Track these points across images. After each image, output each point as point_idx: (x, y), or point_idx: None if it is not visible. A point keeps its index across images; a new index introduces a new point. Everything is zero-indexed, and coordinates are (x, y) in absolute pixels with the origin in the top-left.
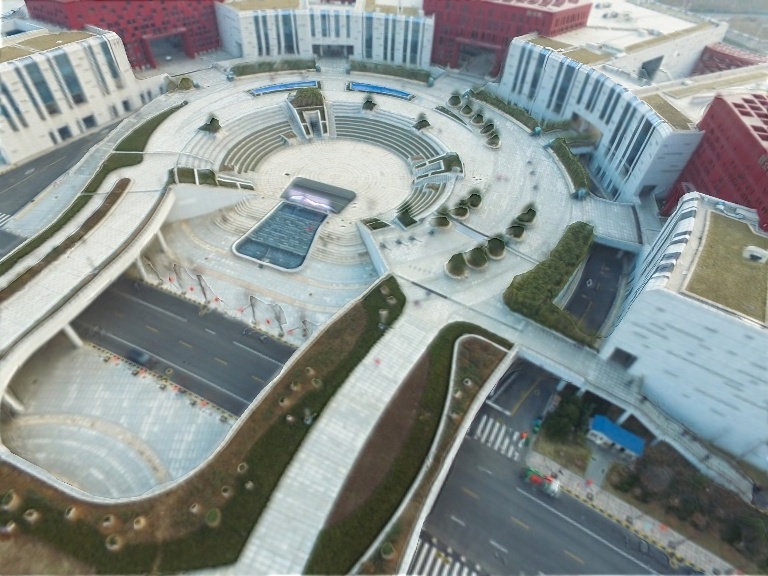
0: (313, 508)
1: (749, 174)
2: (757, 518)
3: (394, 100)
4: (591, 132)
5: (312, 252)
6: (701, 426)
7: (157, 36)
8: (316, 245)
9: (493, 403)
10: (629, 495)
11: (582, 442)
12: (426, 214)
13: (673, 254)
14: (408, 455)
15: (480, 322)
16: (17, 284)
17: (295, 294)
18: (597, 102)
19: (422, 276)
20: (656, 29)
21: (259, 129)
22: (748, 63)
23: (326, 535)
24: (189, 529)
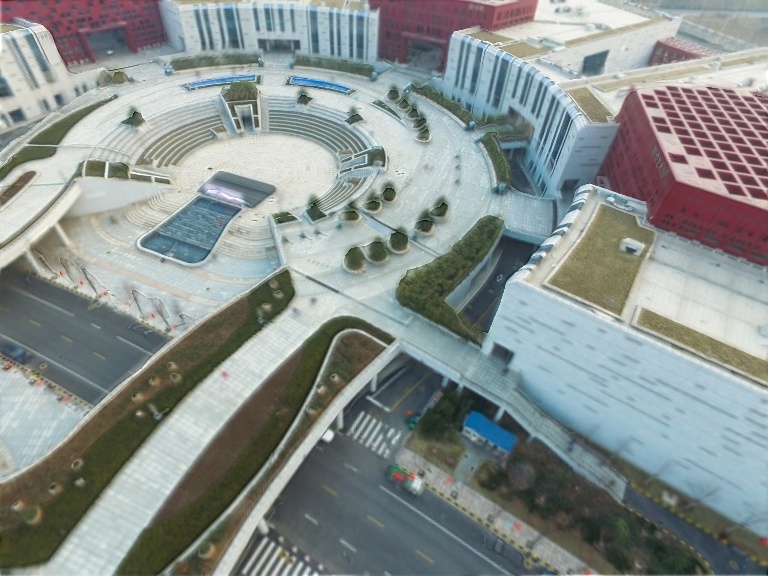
0: (142, 505)
1: (645, 166)
2: (618, 517)
3: (332, 94)
4: (525, 126)
5: (218, 246)
6: (578, 423)
7: (95, 30)
8: (223, 239)
9: (374, 399)
10: (495, 493)
11: (457, 439)
12: (337, 208)
13: (546, 246)
14: (254, 451)
15: (367, 317)
16: None
17: (192, 288)
18: (529, 96)
19: (318, 270)
20: (605, 23)
21: (188, 123)
22: (691, 57)
23: (148, 533)
24: (8, 527)
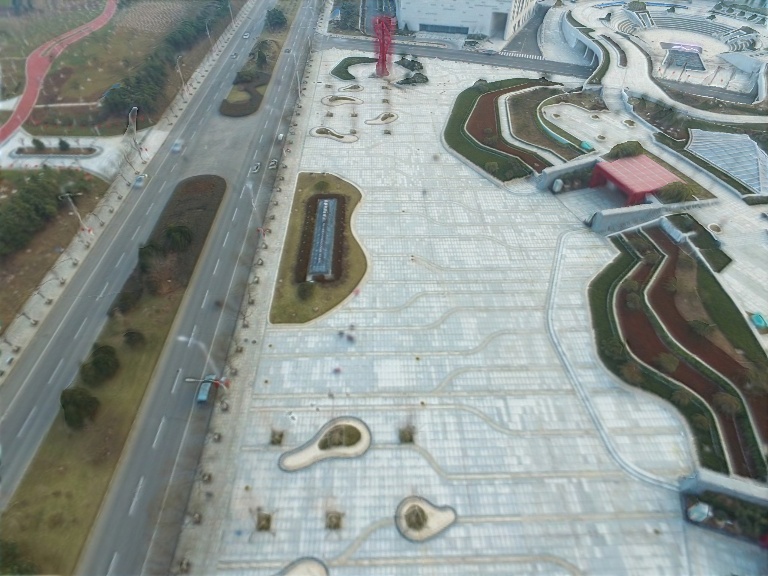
0: None
1: None
2: None
3: (679, 9)
4: None
5: (705, 66)
6: None
7: None
8: (705, 63)
9: None
10: None
11: None
12: (758, 47)
13: None
14: None
15: None
16: (624, 60)
17: None
18: None
19: None
20: None
21: (620, 22)
22: None
23: None
24: None
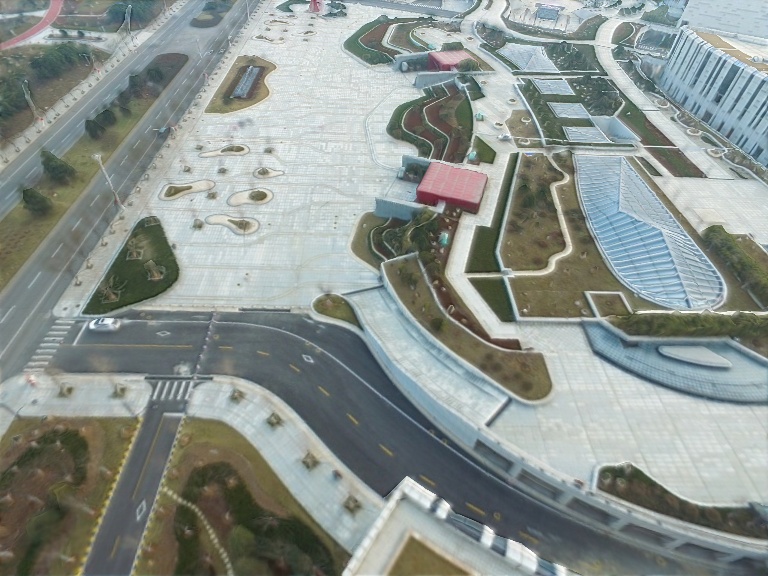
0: None
1: None
2: None
3: None
4: None
5: None
6: None
7: None
8: None
9: None
10: None
11: None
12: (601, 6)
13: None
14: None
15: (635, 22)
16: (489, 6)
17: None
18: None
19: None
20: None
21: None
22: None
23: None
24: None
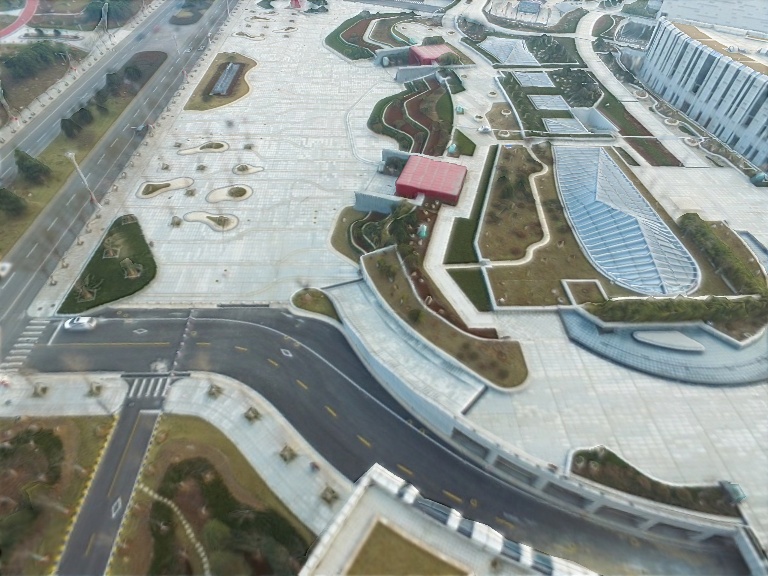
0: None
1: None
2: None
3: None
4: None
5: None
6: None
7: None
8: None
9: None
10: None
11: None
12: None
13: None
14: None
15: None
16: None
17: None
18: None
19: None
20: None
21: None
22: None
23: (594, 30)
24: None
